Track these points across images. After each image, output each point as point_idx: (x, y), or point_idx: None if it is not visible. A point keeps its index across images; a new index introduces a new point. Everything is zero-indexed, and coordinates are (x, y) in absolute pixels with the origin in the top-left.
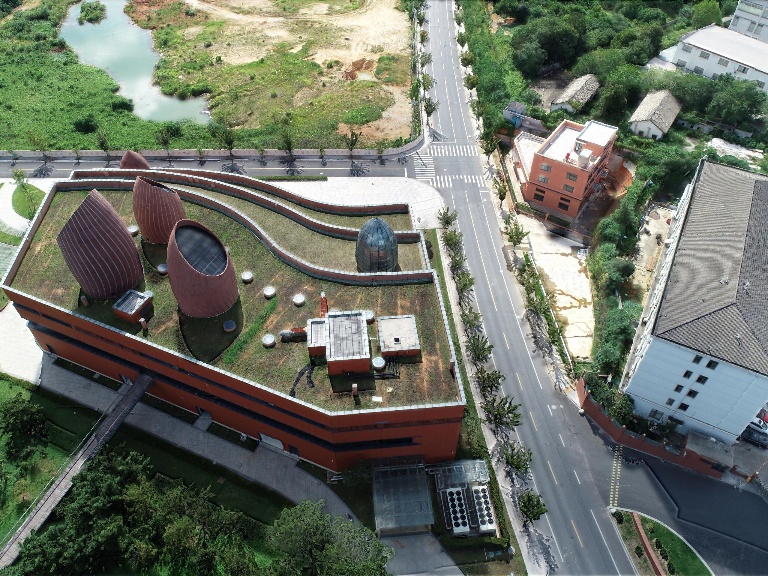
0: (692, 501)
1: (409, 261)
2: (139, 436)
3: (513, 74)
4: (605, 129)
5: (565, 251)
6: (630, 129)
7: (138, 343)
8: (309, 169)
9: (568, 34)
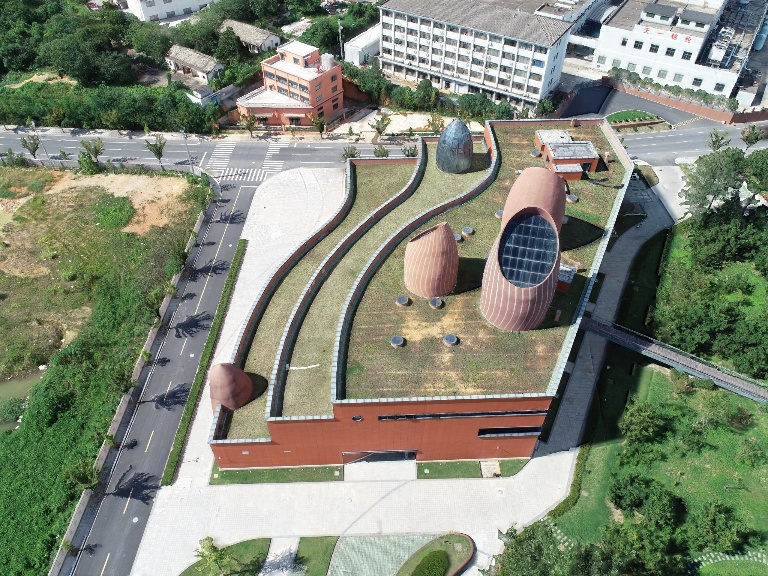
0: (587, 108)
1: None
2: None
3: (124, 90)
4: (291, 45)
5: None
6: (263, 51)
7: None
8: (218, 255)
9: (116, 31)
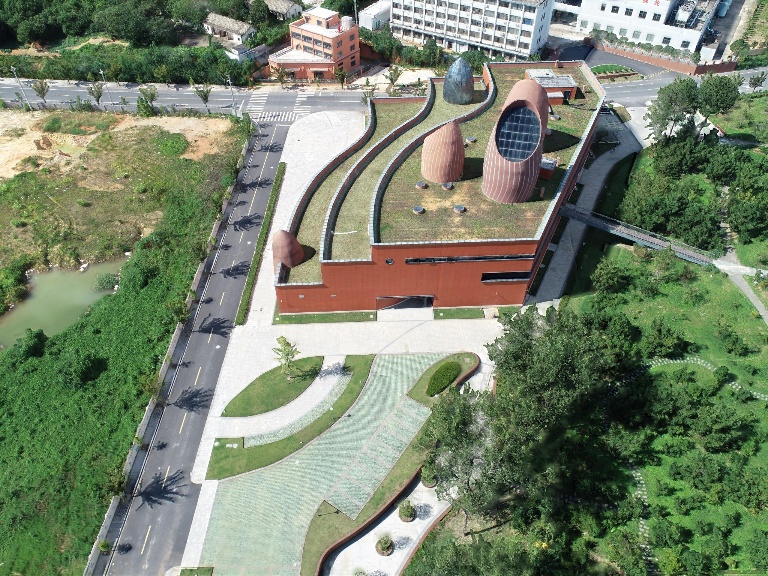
0: None
1: None
2: (592, 230)
3: (171, 49)
4: (314, 11)
5: None
6: (288, 18)
7: None
8: (262, 174)
9: None
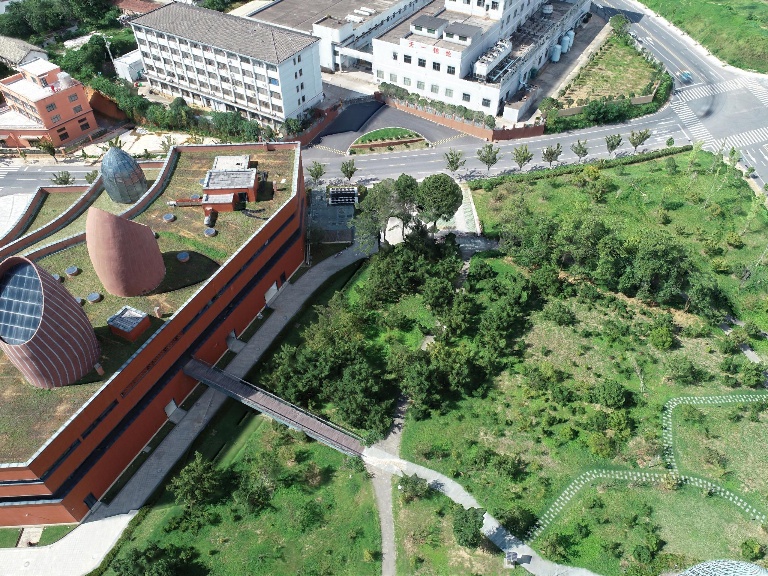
0: (348, 126)
1: None
2: None
3: None
4: (34, 64)
5: (134, 138)
6: None
7: (181, 316)
8: None
9: None
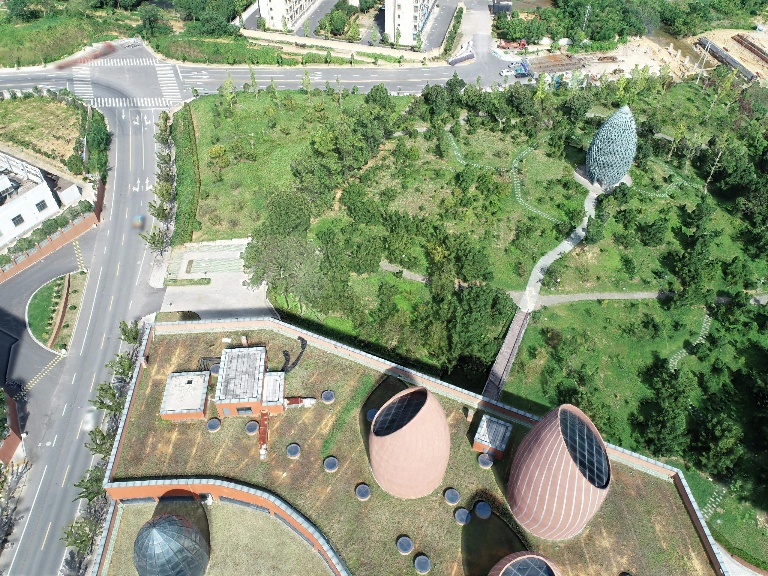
0: None
1: (127, 569)
2: None
3: None
4: None
5: None
6: None
7: None
8: None
9: None
